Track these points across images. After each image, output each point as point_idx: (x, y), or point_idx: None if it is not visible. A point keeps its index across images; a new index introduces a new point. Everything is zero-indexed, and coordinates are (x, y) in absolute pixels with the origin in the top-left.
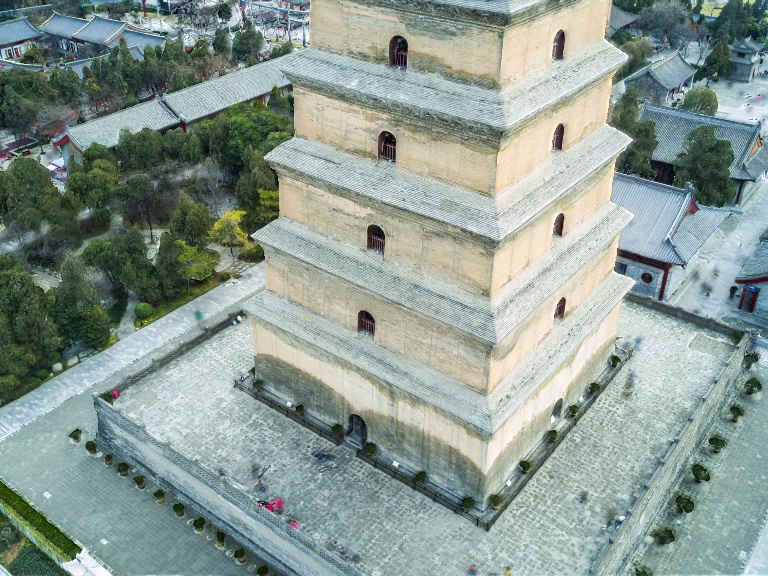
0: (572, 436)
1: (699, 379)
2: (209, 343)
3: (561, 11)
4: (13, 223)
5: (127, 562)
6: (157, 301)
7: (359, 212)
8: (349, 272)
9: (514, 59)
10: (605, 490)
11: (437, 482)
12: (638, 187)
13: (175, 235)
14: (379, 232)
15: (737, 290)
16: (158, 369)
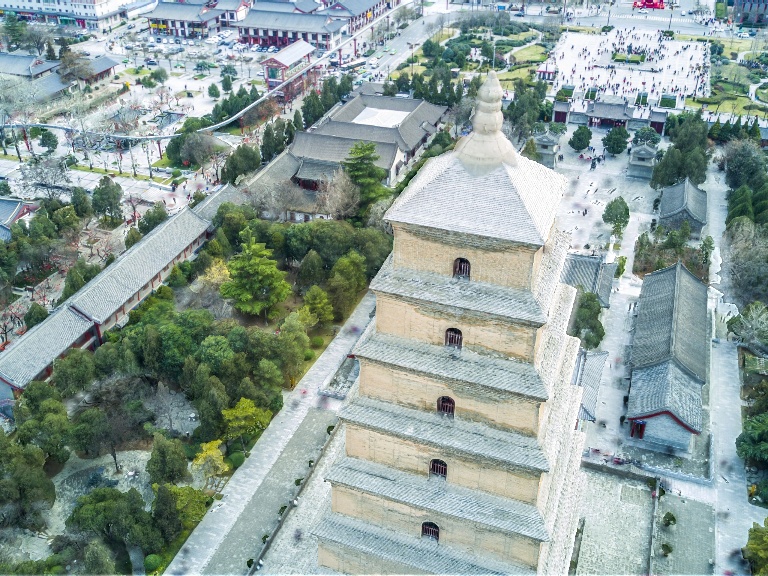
0: None
1: (639, 532)
2: None
3: None
4: None
5: None
6: None
7: (415, 513)
8: (411, 558)
9: None
10: None
11: None
12: None
13: (158, 475)
14: (430, 523)
15: (625, 419)
16: None
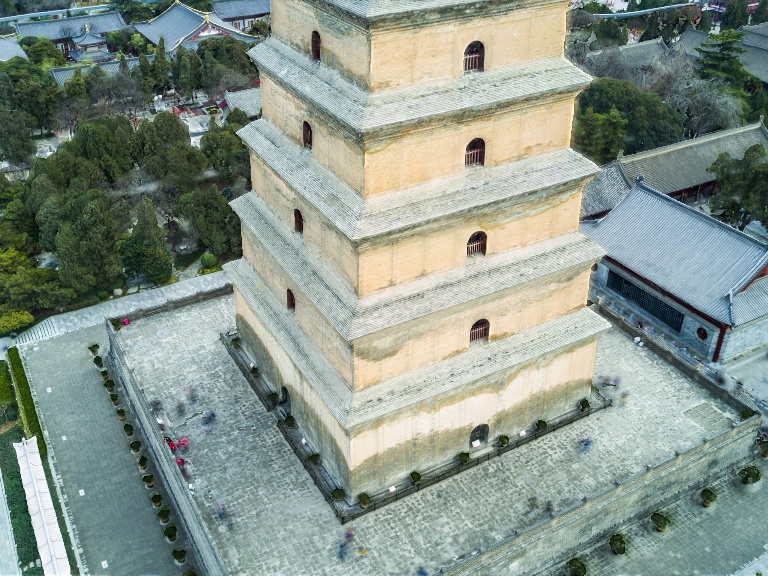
0: (488, 465)
1: (670, 448)
2: (226, 298)
3: (473, 22)
4: (143, 167)
5: (70, 459)
6: (228, 255)
7: (289, 195)
8: (276, 250)
9: (394, 64)
10: (483, 524)
11: (327, 467)
12: (719, 233)
13: None
14: None
15: None
16: (172, 310)
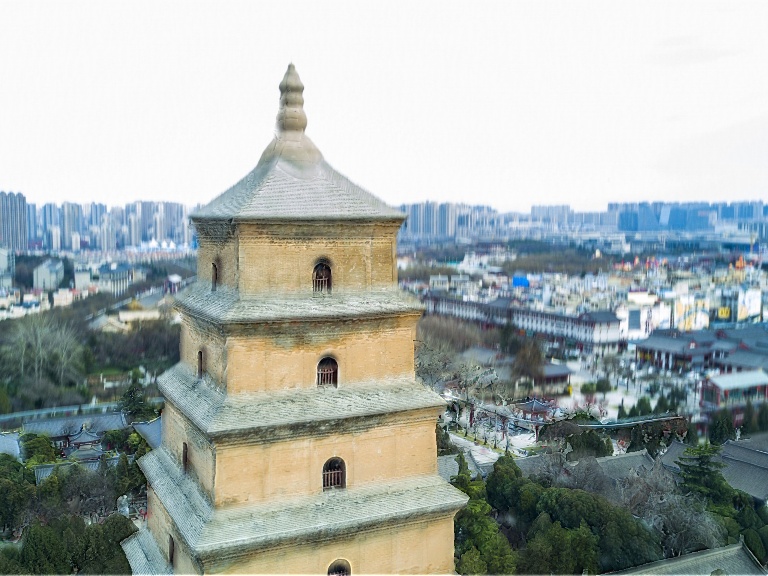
0: None
1: None
2: None
3: (331, 438)
4: (80, 572)
5: None
6: None
7: None
8: None
9: (243, 479)
10: None
11: None
12: None
13: None
14: None
15: None
16: None
